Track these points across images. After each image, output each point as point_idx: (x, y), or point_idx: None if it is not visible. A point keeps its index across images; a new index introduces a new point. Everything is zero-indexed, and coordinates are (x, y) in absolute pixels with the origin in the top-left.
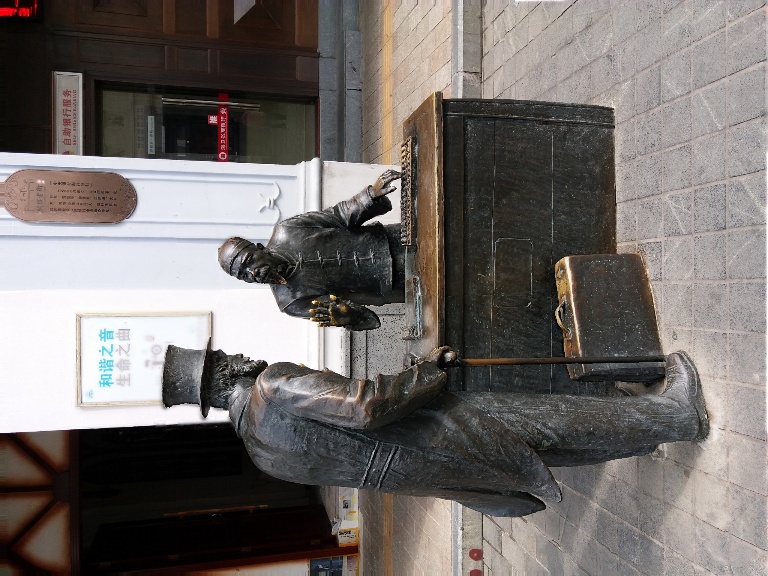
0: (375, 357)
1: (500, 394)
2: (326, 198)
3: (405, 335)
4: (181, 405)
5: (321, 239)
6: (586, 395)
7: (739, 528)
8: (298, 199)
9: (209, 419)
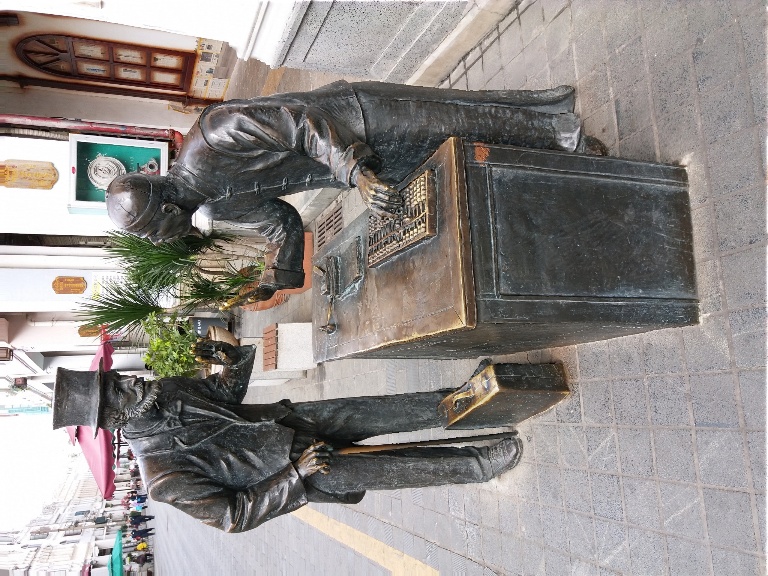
0: (335, 24)
1: (352, 477)
2: None
3: (330, 277)
4: (58, 1)
5: (264, 171)
6: (425, 460)
7: (466, 496)
8: None
9: (99, 18)
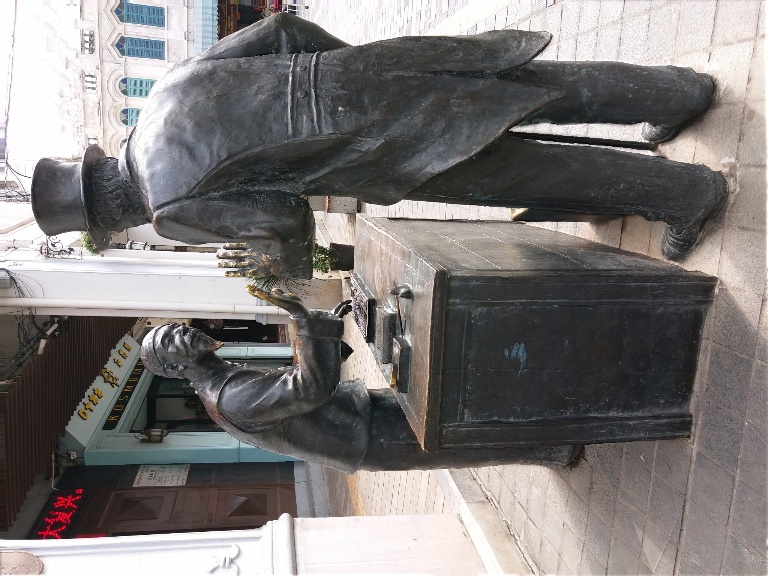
0: None
1: None
2: (301, 547)
3: None
4: None
5: None
6: None
7: None
8: (264, 555)
9: None
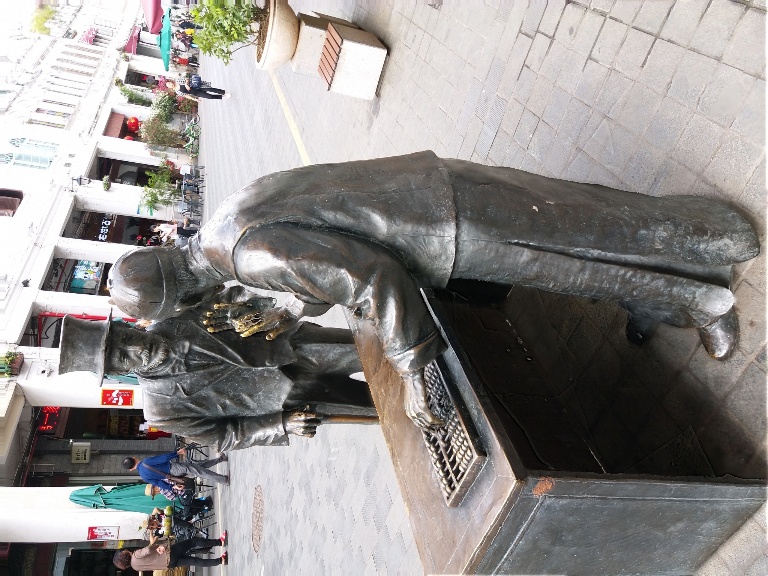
0: None
1: None
2: None
3: None
4: None
5: None
6: None
7: None
8: None
9: None
